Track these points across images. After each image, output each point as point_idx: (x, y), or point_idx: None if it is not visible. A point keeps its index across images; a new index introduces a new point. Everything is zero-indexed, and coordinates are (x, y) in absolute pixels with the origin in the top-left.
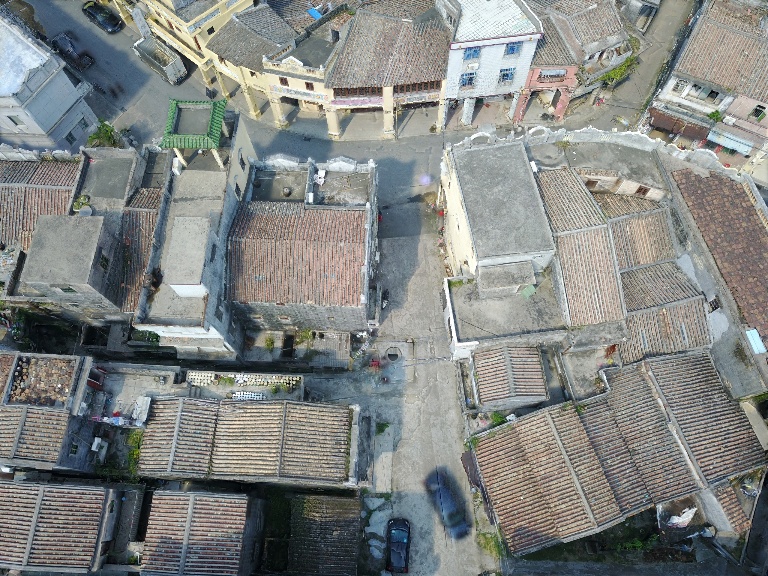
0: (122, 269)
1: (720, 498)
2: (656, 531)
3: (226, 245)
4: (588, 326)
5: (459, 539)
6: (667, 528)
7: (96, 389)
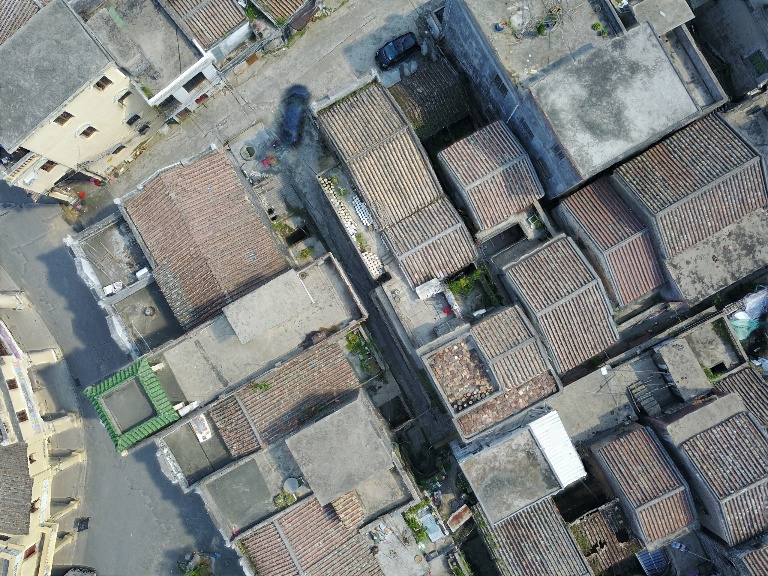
0: (323, 410)
1: None
2: None
3: None
4: None
5: (364, 11)
6: None
7: None
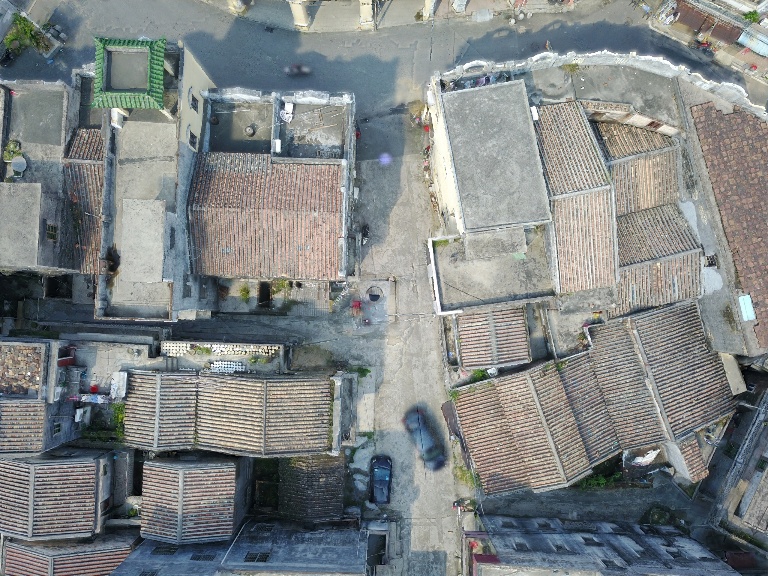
0: (73, 229)
1: (684, 451)
2: (620, 469)
3: (186, 215)
4: (578, 291)
5: (437, 472)
6: (631, 467)
7: (68, 365)
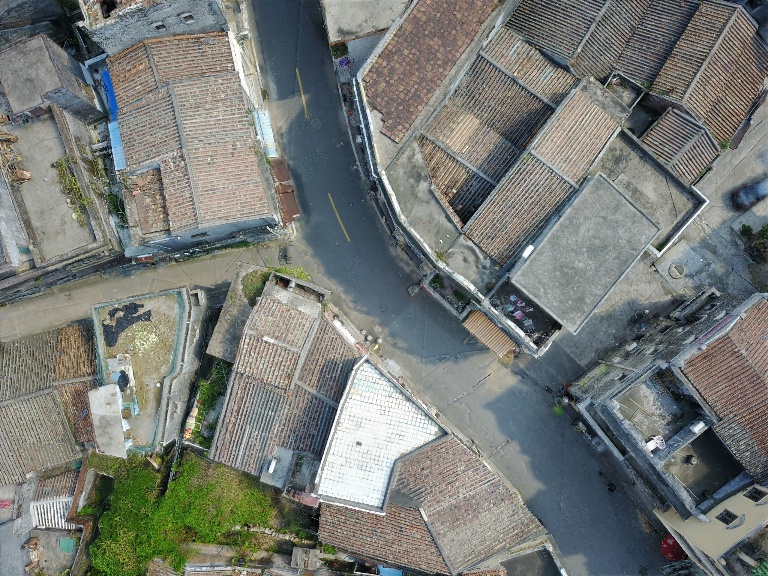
0: None
1: None
2: None
3: None
4: None
5: (767, 115)
6: None
7: None
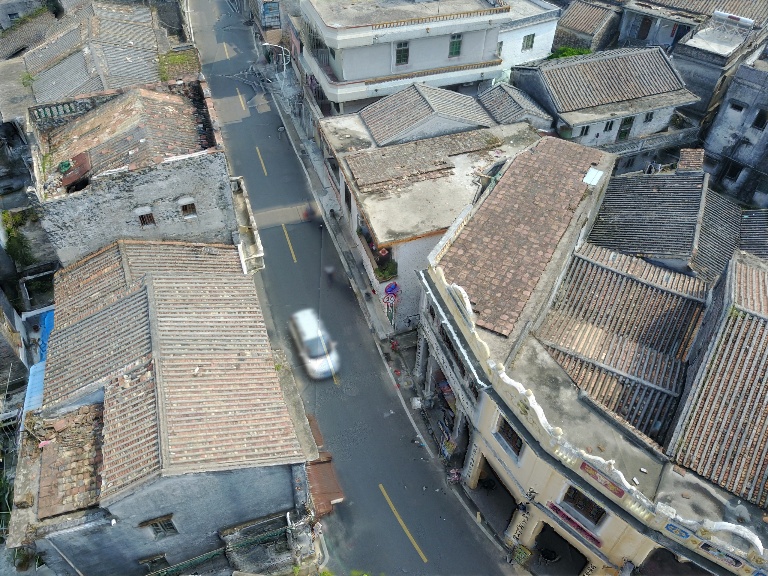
0: None
1: (700, 165)
2: None
3: None
4: None
5: None
6: None
7: None
